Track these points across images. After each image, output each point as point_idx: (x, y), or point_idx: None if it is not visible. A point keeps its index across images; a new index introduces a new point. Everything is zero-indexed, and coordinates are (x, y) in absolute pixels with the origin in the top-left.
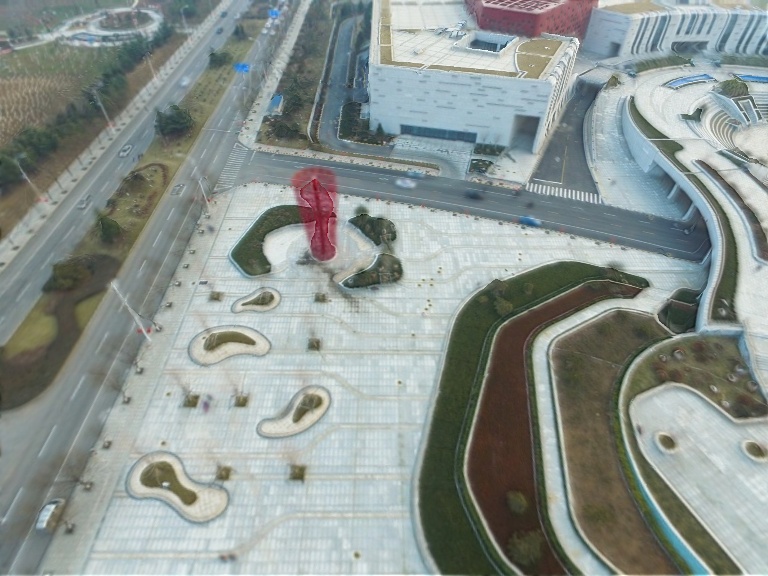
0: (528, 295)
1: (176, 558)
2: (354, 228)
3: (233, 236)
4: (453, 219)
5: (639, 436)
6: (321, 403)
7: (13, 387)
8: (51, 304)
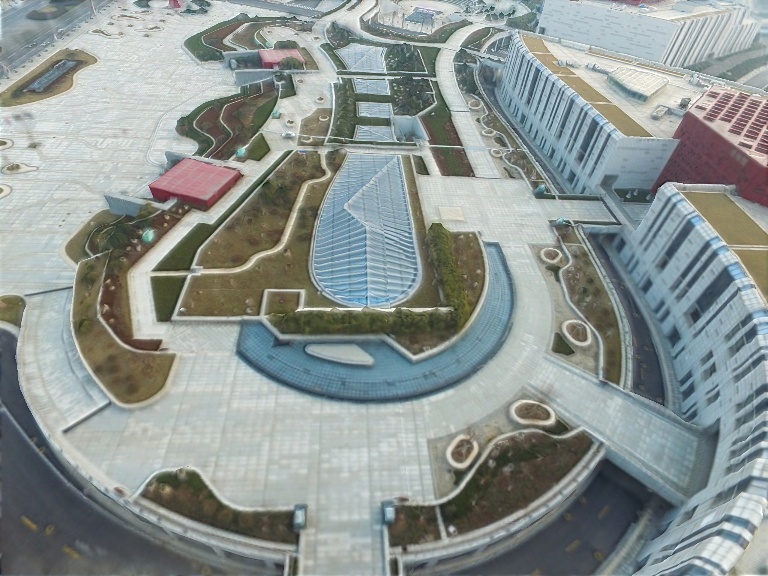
0: (255, 19)
1: (103, 41)
2: (192, 3)
3: (135, 0)
4: (240, 6)
5: (262, 31)
6: (160, 28)
7: (43, 15)
8: (54, 5)
